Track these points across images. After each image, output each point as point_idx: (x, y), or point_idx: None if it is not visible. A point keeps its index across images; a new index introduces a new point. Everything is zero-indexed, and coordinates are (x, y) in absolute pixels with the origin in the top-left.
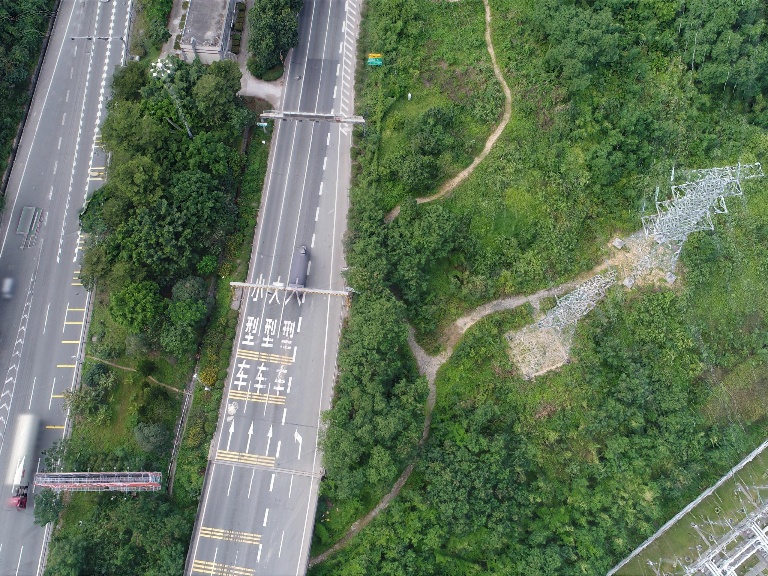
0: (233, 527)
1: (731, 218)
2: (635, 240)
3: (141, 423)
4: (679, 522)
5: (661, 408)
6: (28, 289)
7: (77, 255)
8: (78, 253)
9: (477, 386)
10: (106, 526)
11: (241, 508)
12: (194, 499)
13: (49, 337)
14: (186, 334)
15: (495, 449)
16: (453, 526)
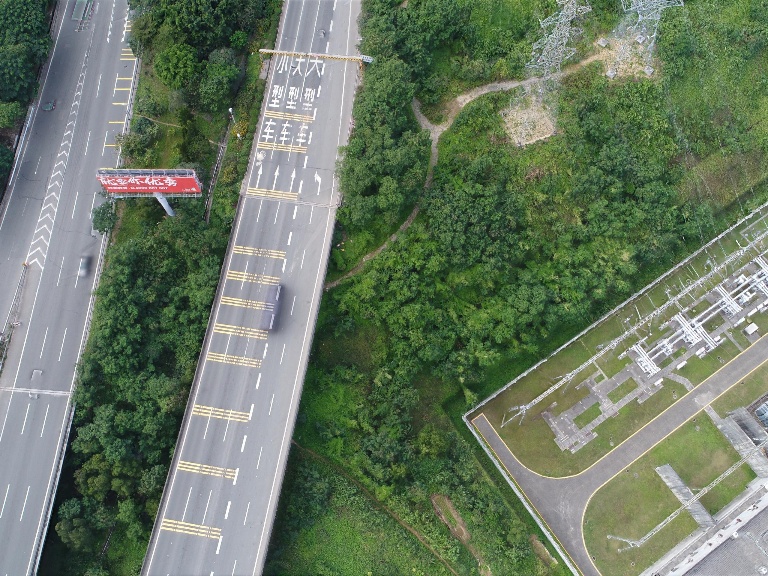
0: (262, 246)
1: (705, 22)
2: (618, 40)
3: (182, 162)
4: (654, 290)
5: (638, 179)
6: (82, 63)
7: (125, 36)
8: (126, 35)
9: (474, 151)
10: (154, 235)
11: (268, 231)
12: (228, 226)
13: (101, 100)
14: (222, 84)
15: (489, 193)
16: (452, 258)
